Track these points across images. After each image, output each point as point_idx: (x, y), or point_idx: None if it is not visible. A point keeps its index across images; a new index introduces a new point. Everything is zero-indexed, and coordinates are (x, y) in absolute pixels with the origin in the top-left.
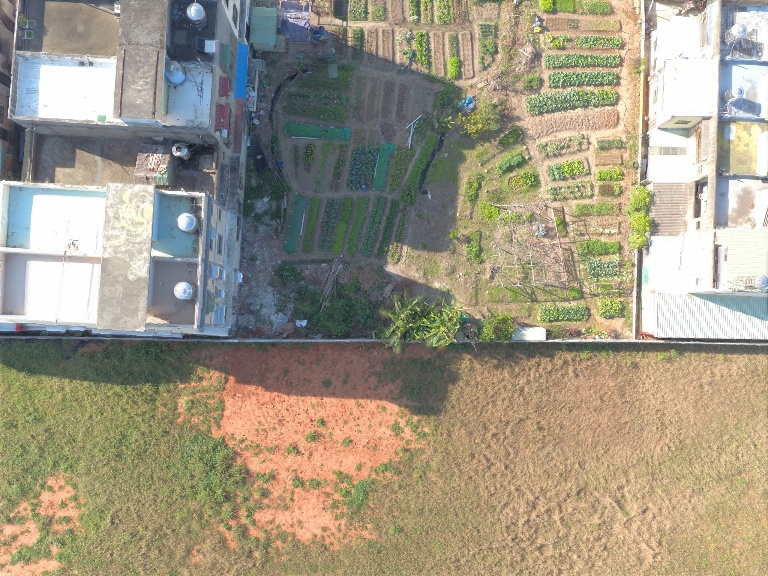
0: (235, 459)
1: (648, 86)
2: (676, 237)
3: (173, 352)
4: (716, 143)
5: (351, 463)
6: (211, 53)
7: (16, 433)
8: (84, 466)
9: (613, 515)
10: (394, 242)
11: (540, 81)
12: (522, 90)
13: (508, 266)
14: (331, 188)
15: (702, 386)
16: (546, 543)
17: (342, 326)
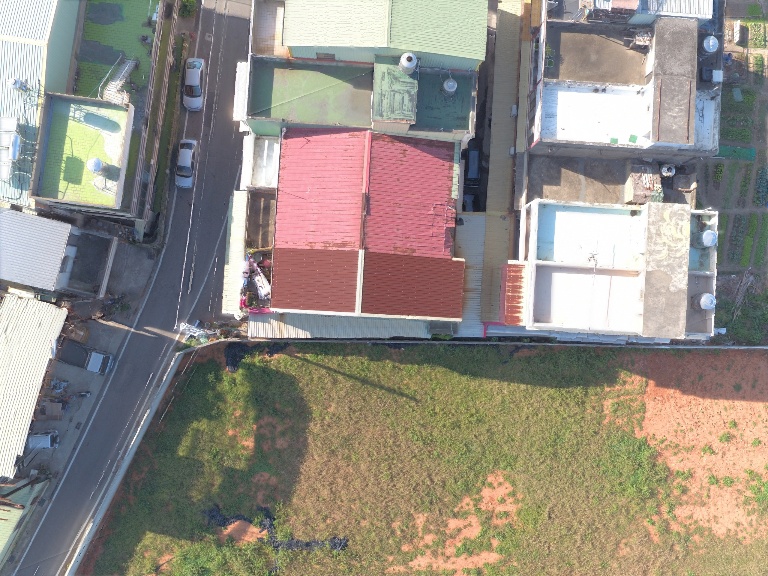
0: (656, 458)
1: None
2: None
3: (601, 357)
4: None
5: (760, 462)
6: (717, 82)
7: (459, 433)
8: (523, 464)
9: None
10: None
11: None
12: None
13: None
14: (738, 205)
15: None
16: None
17: (760, 334)
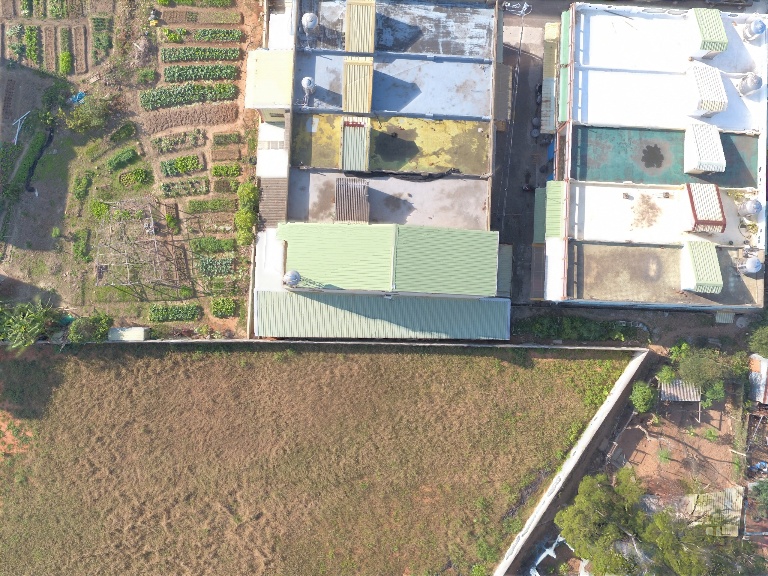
0: None
1: None
2: None
3: None
4: (289, 136)
5: None
6: None
7: None
8: None
9: (225, 521)
10: None
11: (155, 75)
12: (137, 85)
13: (117, 265)
14: None
15: (321, 387)
16: (151, 550)
17: None
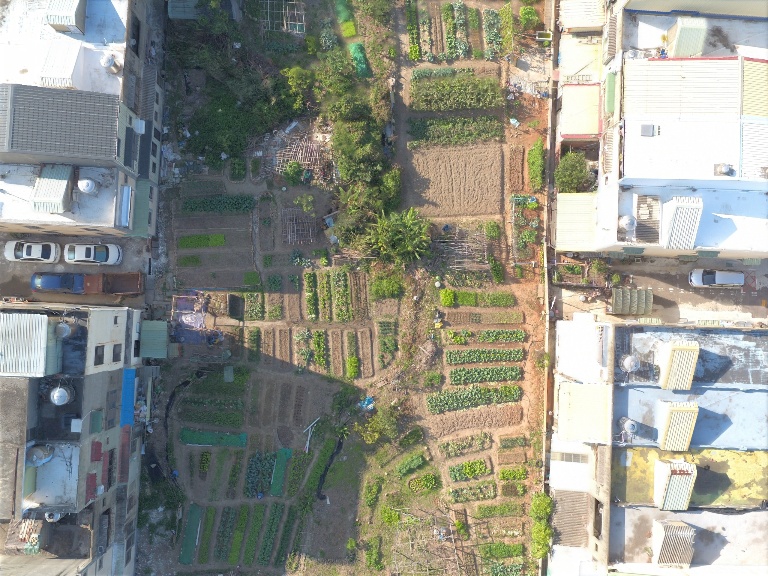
0: None
1: (553, 378)
2: (578, 548)
3: None
4: (610, 476)
5: None
6: (78, 431)
7: None
8: None
9: None
10: (292, 550)
11: (441, 379)
12: (423, 388)
13: (409, 572)
14: (227, 496)
15: None
16: None
17: None
